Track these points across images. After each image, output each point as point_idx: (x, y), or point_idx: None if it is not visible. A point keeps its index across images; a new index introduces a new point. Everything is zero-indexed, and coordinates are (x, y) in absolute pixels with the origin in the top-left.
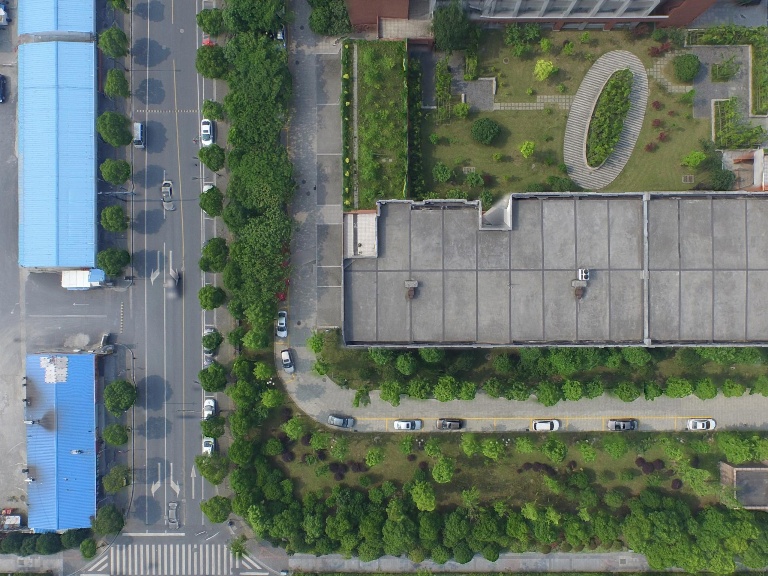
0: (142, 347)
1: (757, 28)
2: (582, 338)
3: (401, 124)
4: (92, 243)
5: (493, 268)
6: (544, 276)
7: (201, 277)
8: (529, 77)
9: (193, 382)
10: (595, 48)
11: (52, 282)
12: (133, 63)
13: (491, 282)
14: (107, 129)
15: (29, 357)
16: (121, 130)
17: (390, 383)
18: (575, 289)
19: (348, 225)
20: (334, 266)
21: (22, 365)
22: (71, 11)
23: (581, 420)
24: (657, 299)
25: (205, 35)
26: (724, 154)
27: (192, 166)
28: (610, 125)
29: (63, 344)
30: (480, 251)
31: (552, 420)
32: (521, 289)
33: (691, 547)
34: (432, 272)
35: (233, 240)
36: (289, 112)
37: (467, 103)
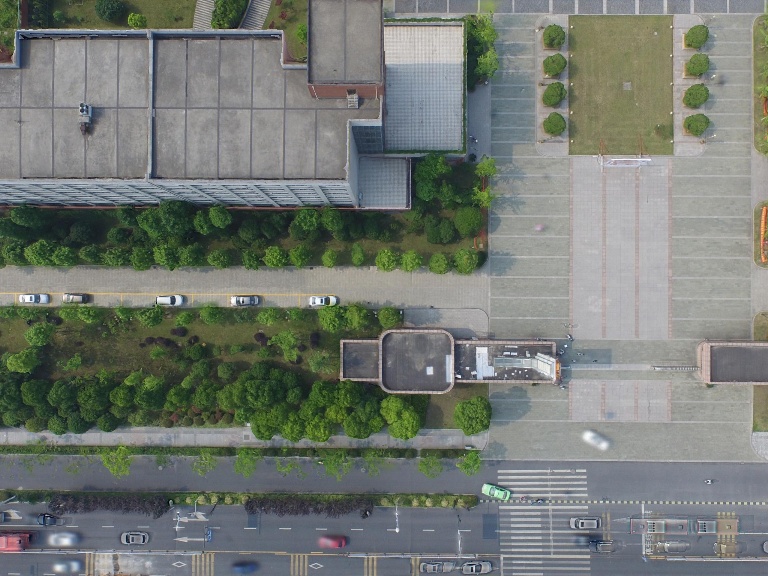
0: None
1: None
2: (91, 175)
3: None
4: None
5: (4, 105)
6: (53, 114)
7: None
8: None
9: None
10: None
11: None
12: None
13: (2, 119)
14: None
15: None
16: None
17: None
18: None
19: None
20: None
21: None
22: None
23: (206, 296)
24: (164, 137)
25: None
26: None
27: None
28: (225, 1)
29: None
30: None
31: (174, 295)
32: (31, 126)
33: (288, 415)
34: None
35: None
36: None
37: None
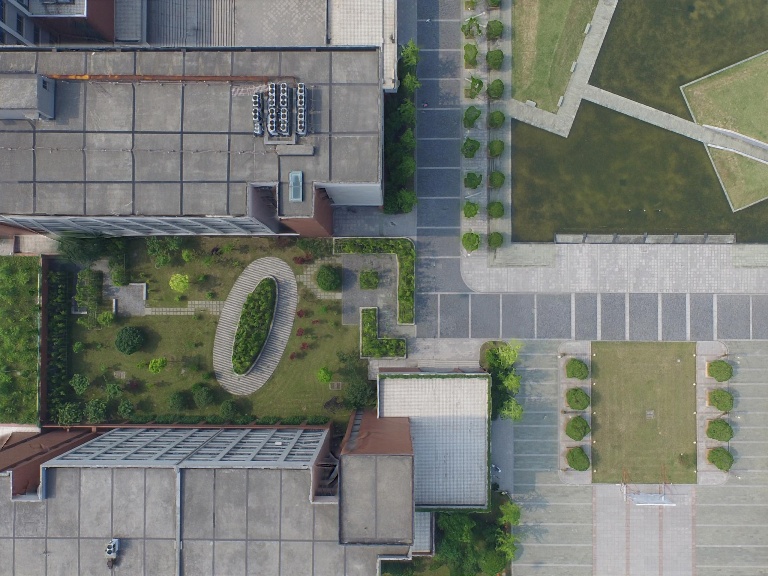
0: None
1: (394, 243)
2: None
3: (35, 338)
4: None
5: (29, 536)
6: (80, 544)
7: None
8: None
9: None
10: (246, 254)
11: None
12: None
13: (27, 550)
14: None
15: None
16: None
17: None
18: None
19: None
20: None
21: None
22: None
23: None
24: (191, 568)
25: None
26: (371, 362)
27: None
28: (246, 339)
29: None
30: (17, 518)
31: None
32: (57, 557)
33: None
34: None
35: None
36: None
37: (119, 308)
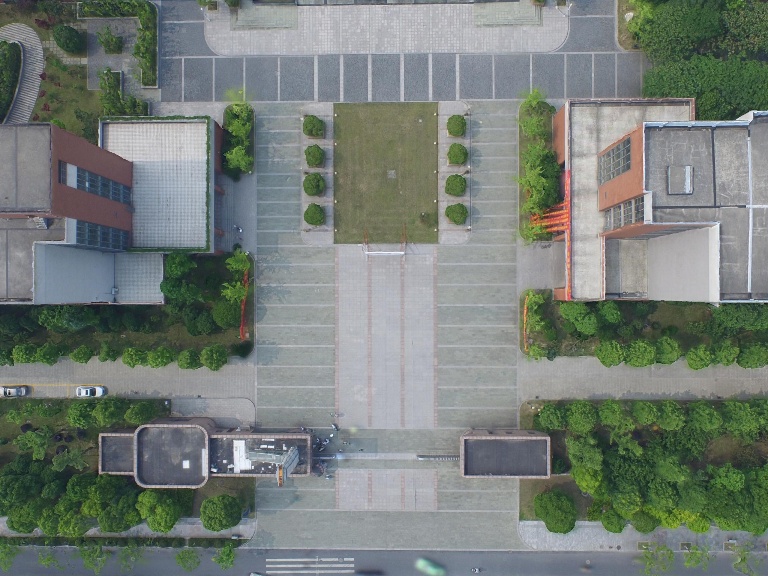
0: None
1: None
2: None
3: None
4: None
5: None
6: None
7: None
8: None
9: None
10: None
11: None
12: None
13: None
14: None
15: None
16: None
17: None
18: None
19: None
20: None
21: None
22: None
23: None
24: None
25: None
26: None
27: None
28: None
29: None
30: None
31: None
32: None
33: (42, 510)
34: None
35: None
36: None
37: None
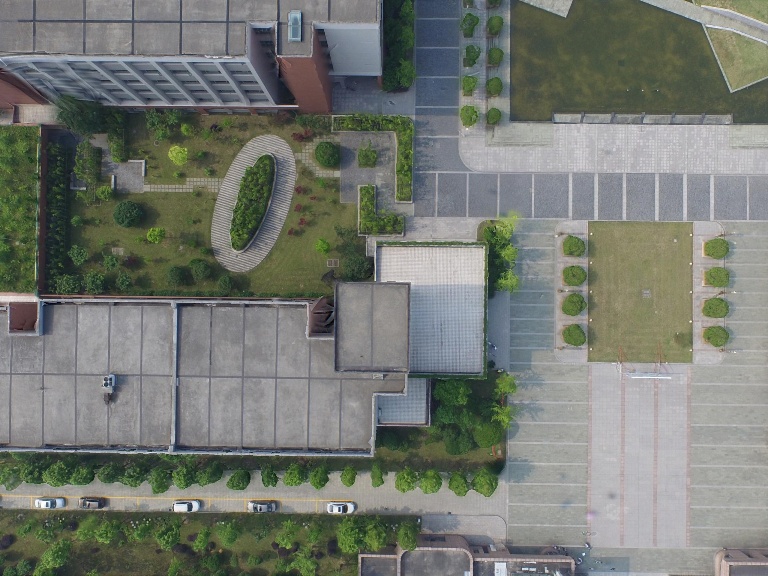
0: None
1: (392, 117)
2: (113, 442)
3: (34, 208)
4: None
5: (26, 372)
6: (76, 380)
7: None
8: None
9: None
10: (244, 132)
11: None
12: None
13: (24, 386)
14: None
15: None
16: None
17: (3, 467)
18: None
19: None
20: None
21: None
22: None
23: (223, 501)
24: (187, 405)
25: None
26: (368, 239)
27: None
28: (244, 211)
29: None
30: (15, 355)
31: (191, 501)
32: (54, 393)
33: None
34: None
35: None
36: None
37: (117, 184)
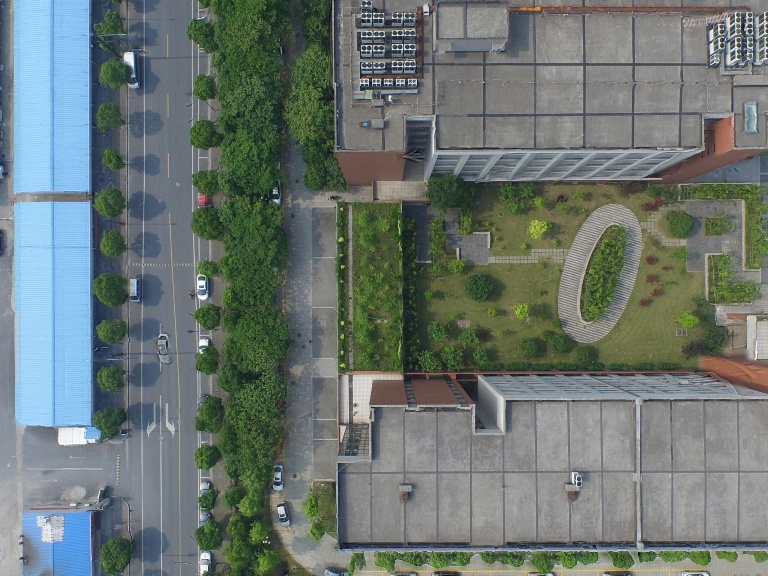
0: (138, 499)
1: (750, 187)
2: (575, 539)
3: (396, 285)
4: (88, 402)
5: (487, 470)
6: (537, 478)
7: (197, 431)
8: (523, 231)
9: (189, 537)
10: (589, 202)
11: (48, 435)
12: (129, 216)
13: (485, 484)
14: (103, 294)
15: (26, 514)
16: (117, 292)
17: None
18: (568, 491)
19: (343, 385)
20: (330, 419)
21: (19, 519)
22: (67, 171)
23: (576, 572)
24: (650, 501)
25: (201, 196)
26: (718, 308)
27: (188, 320)
28: (604, 284)
29: (60, 497)
30: (474, 453)
31: (547, 574)
32: (514, 491)
33: None
34: (426, 474)
35: (229, 401)
36: (285, 265)
37: (462, 257)
